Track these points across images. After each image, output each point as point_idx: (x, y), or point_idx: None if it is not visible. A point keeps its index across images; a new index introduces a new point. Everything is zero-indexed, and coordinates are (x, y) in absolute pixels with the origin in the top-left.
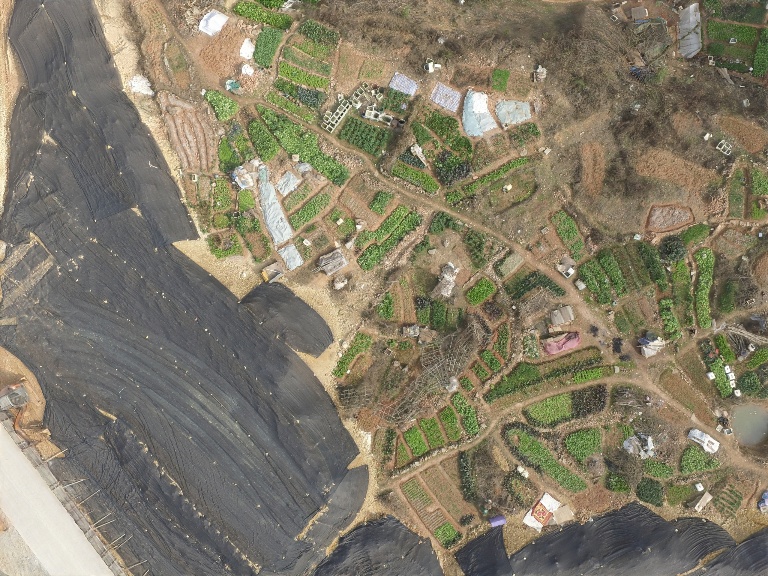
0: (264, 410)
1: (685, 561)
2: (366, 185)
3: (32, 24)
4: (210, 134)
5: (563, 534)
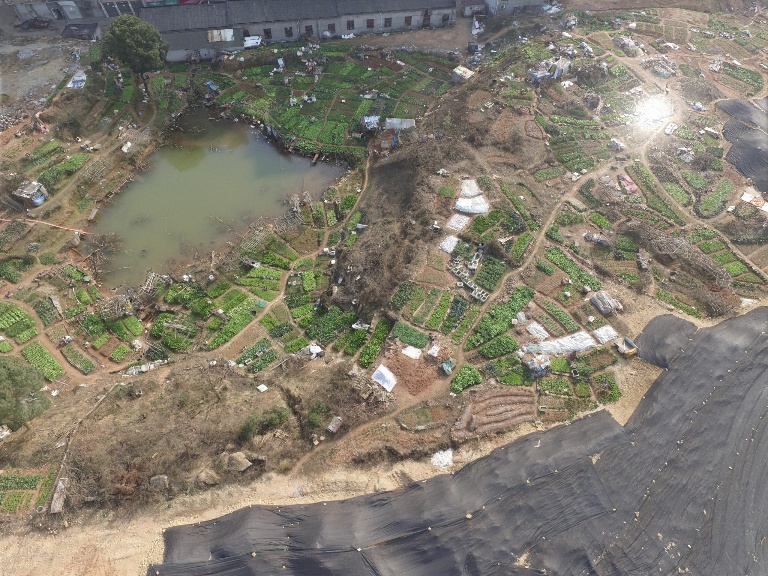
0: (764, 359)
1: (759, 134)
2: (532, 275)
3: (379, 570)
4: (497, 391)
5: (767, 191)
